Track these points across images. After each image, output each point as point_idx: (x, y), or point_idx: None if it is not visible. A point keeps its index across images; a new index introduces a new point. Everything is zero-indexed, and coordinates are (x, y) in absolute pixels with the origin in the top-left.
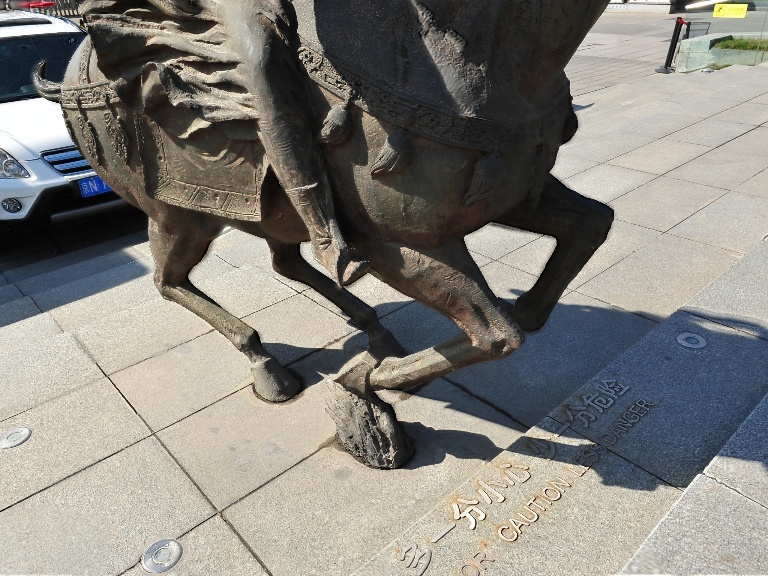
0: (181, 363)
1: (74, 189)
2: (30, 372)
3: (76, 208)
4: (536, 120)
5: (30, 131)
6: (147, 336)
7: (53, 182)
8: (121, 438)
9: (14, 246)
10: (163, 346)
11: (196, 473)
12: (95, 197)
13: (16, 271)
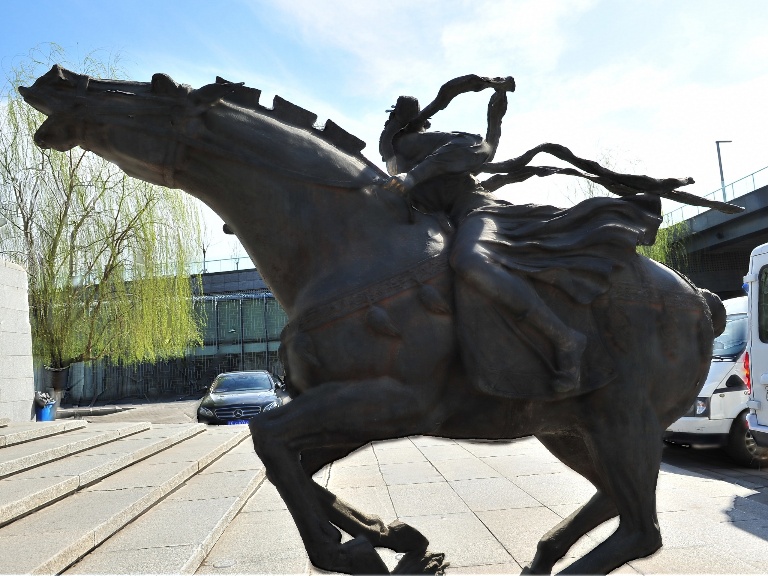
0: (610, 575)
1: None
2: None
3: None
4: None
5: None
6: (677, 568)
7: None
8: (523, 554)
9: None
10: (650, 572)
11: (458, 568)
12: None
13: None
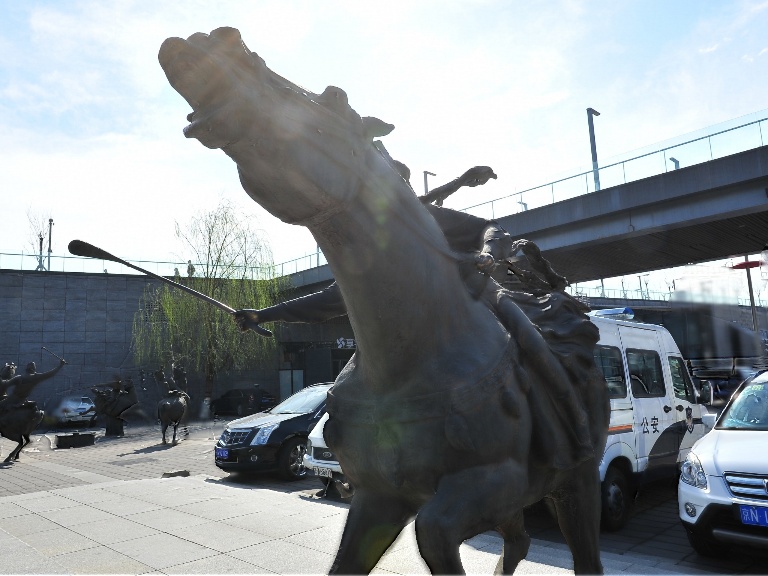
0: None
1: (735, 512)
2: (475, 575)
3: (738, 532)
4: (373, 406)
5: (734, 454)
6: None
7: (721, 499)
8: None
9: (713, 555)
10: None
11: None
12: (760, 529)
13: (669, 565)
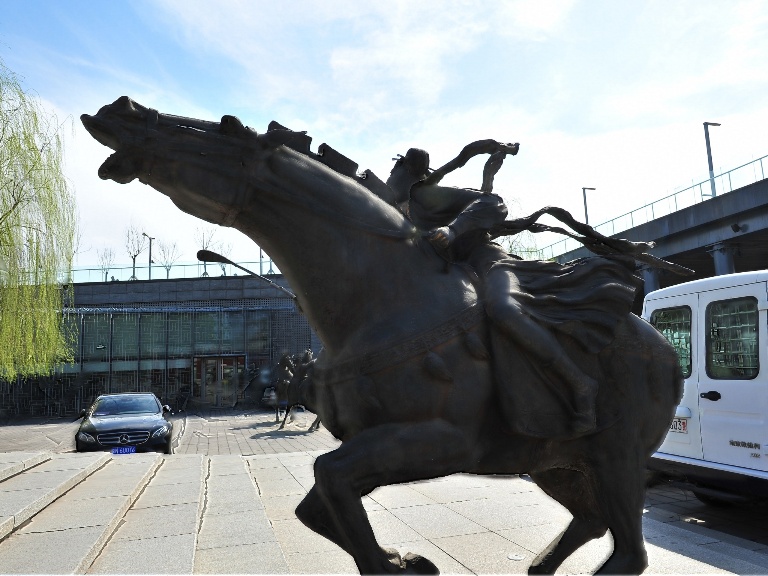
0: None
1: None
2: None
3: None
4: None
5: None
6: None
7: None
8: None
9: None
10: None
11: None
12: None
13: None
